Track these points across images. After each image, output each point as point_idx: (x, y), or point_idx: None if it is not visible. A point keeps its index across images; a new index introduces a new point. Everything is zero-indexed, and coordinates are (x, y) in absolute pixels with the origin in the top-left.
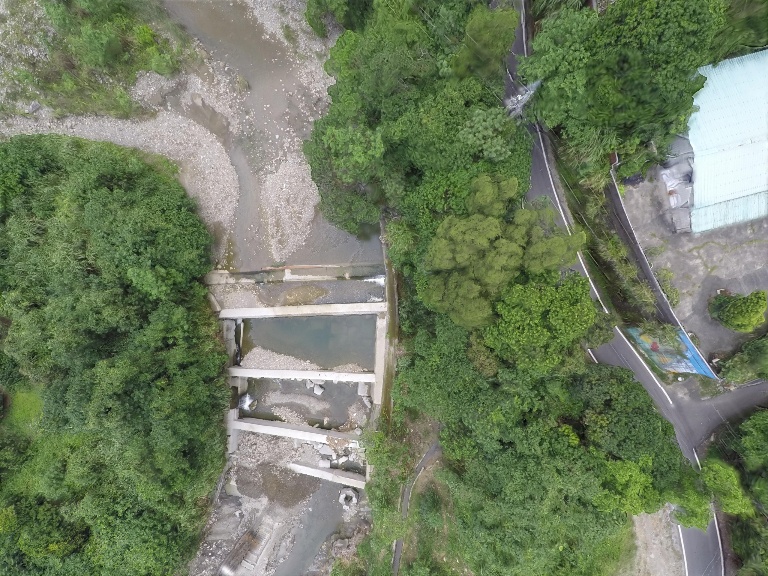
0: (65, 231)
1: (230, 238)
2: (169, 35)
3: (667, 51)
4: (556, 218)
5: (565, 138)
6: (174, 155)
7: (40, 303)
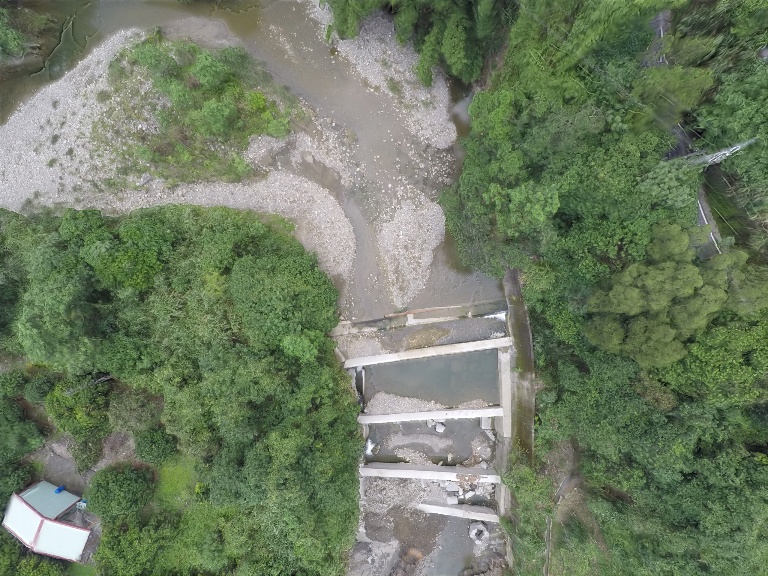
0: (206, 303)
1: (350, 289)
2: (275, 97)
3: None
4: (710, 249)
5: (746, 180)
6: (288, 213)
7: (187, 377)
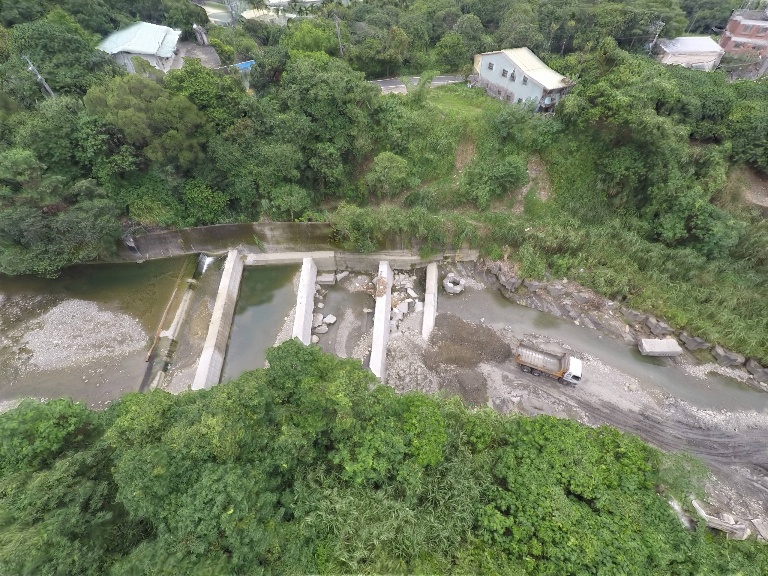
0: None
1: None
2: None
3: None
4: None
5: (88, 88)
6: None
7: None
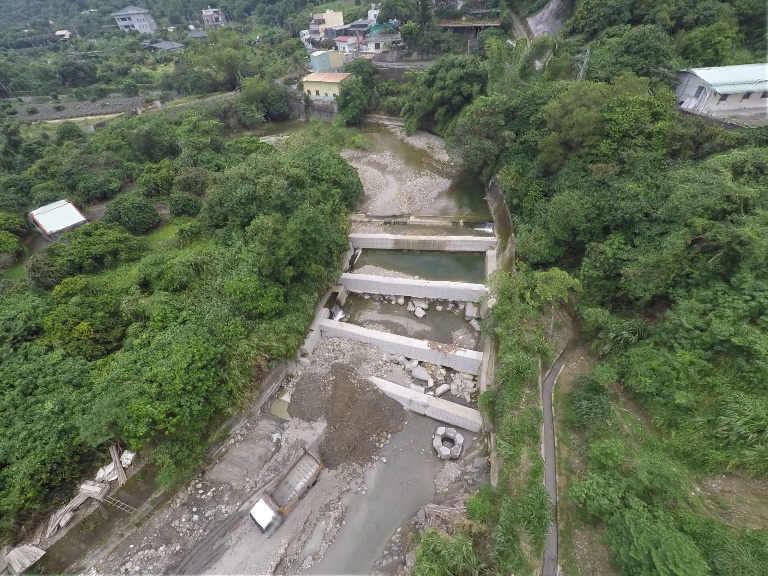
0: None
1: (372, 202)
2: None
3: (650, 35)
4: None
5: None
6: None
7: None
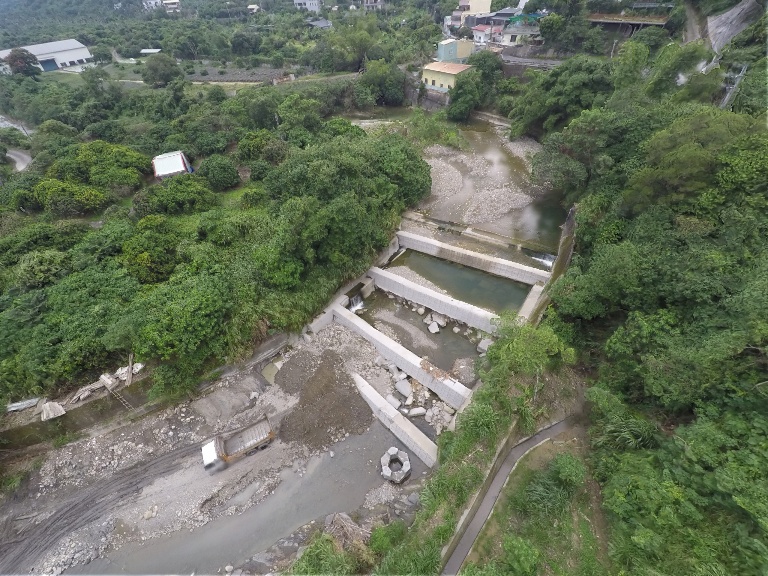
0: None
1: (437, 204)
2: (460, 144)
3: None
4: None
5: None
6: None
7: None
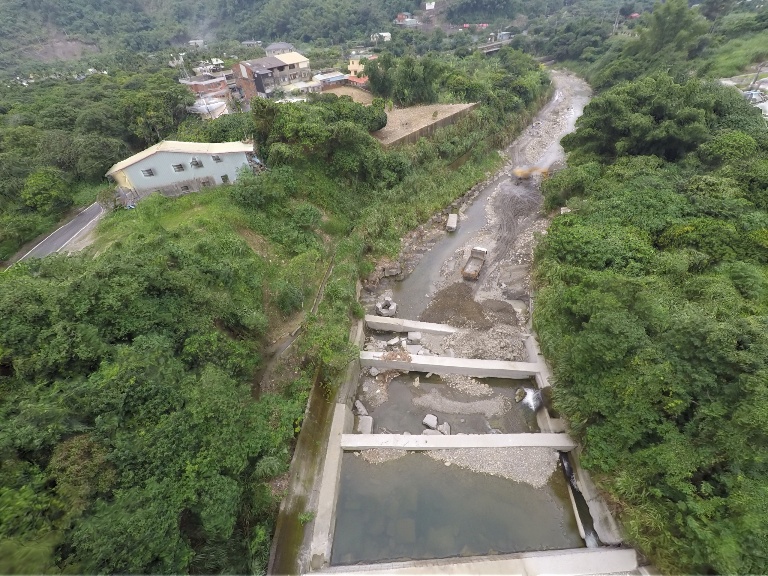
0: None
1: None
2: None
3: None
4: None
5: None
6: None
7: None
